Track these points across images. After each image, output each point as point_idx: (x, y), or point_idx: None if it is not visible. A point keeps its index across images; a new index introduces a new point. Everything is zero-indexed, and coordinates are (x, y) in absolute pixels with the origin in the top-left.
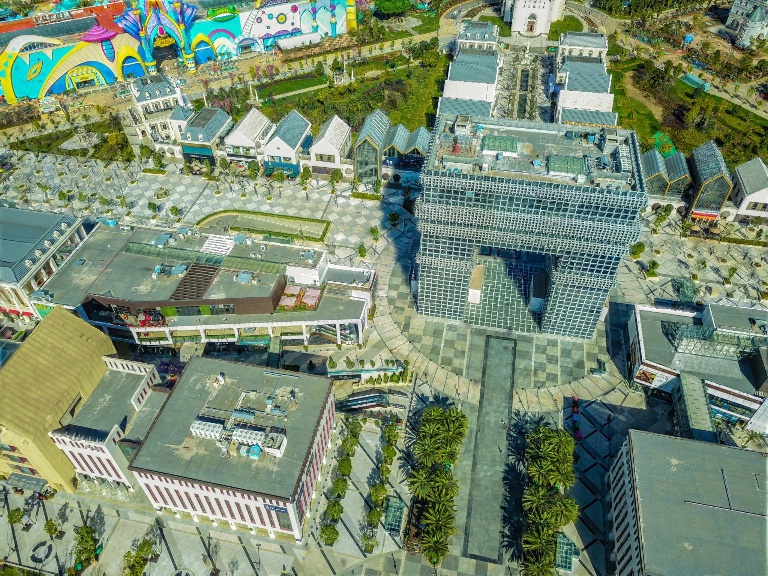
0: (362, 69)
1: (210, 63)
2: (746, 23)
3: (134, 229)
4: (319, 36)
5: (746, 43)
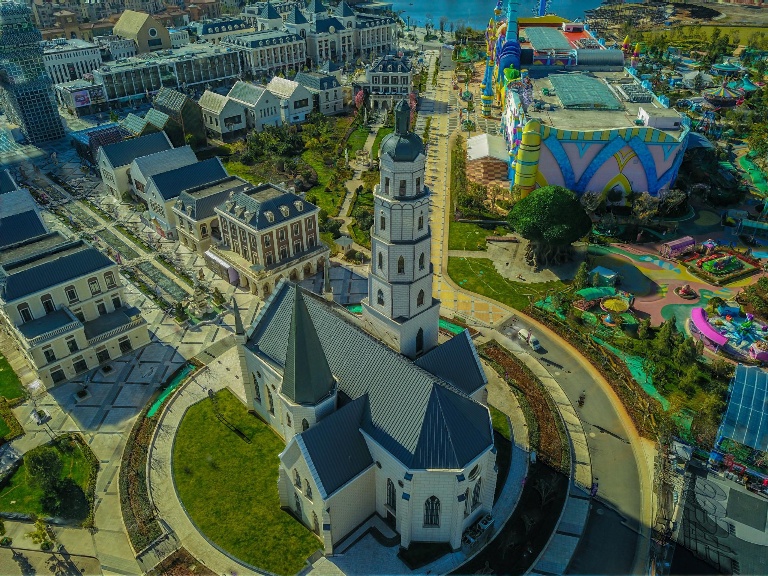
0: (375, 180)
1: (499, 124)
2: None
3: (216, 53)
4: (479, 156)
5: None
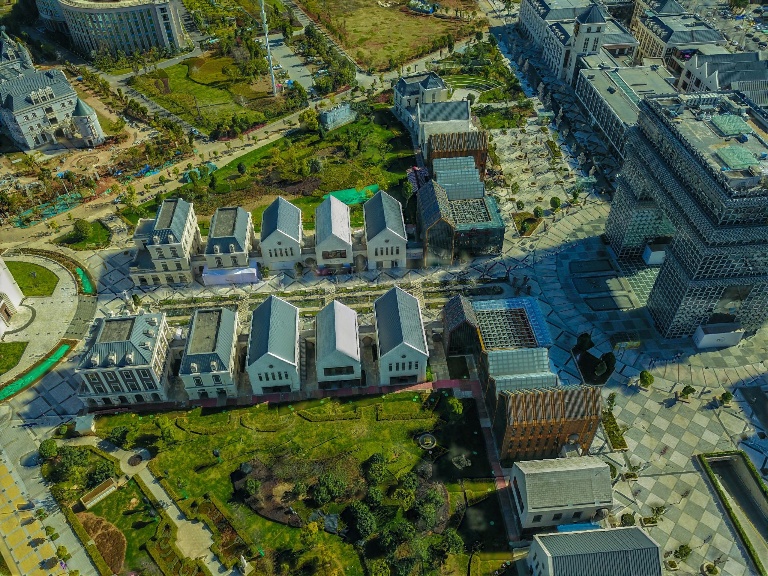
0: (174, 571)
1: None
2: (88, 120)
3: None
4: None
5: (102, 136)
